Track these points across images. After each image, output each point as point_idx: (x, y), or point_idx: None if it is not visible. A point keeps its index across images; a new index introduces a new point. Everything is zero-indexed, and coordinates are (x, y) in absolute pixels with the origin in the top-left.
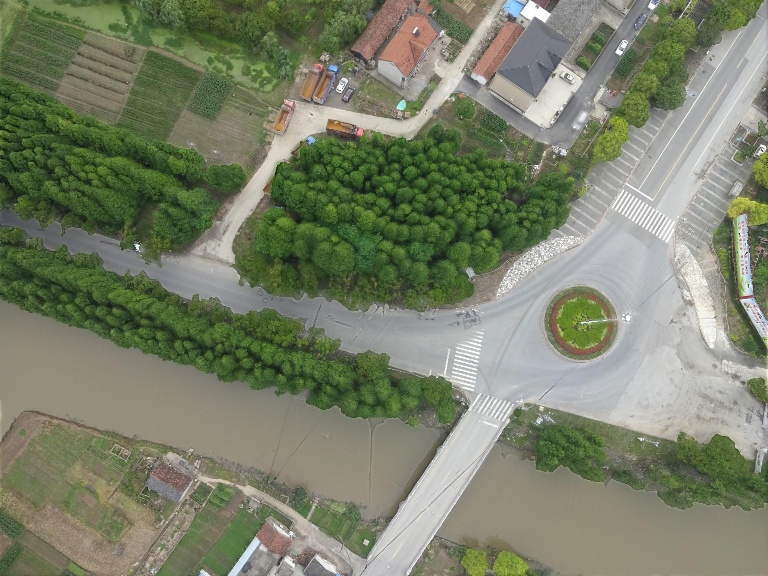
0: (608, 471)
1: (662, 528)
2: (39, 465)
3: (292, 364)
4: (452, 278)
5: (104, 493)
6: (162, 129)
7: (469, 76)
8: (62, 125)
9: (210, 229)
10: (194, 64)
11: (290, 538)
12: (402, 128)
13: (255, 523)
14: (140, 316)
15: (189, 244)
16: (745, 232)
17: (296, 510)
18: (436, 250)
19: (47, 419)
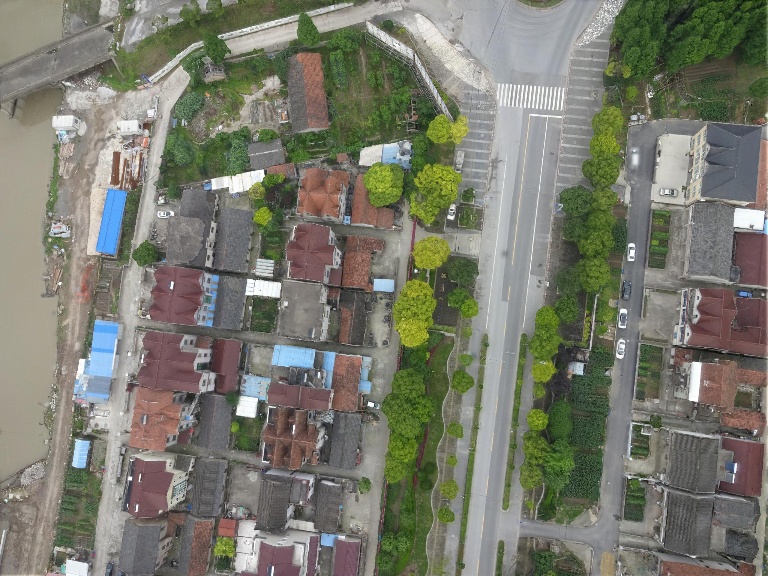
0: None
1: None
2: None
3: None
4: None
5: None
6: None
7: None
8: None
9: None
10: None
11: None
12: None
13: None
14: None
15: None
16: None
17: None
18: None
19: None
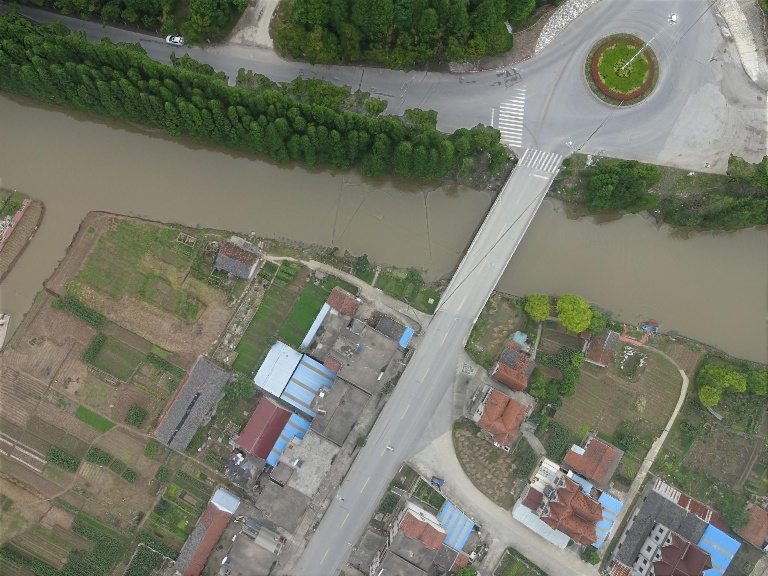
0: (660, 215)
1: (715, 277)
2: (111, 260)
3: (344, 116)
4: (492, 19)
5: (176, 280)
6: None
7: None
8: None
9: (245, 16)
10: None
11: (358, 301)
12: None
13: (323, 294)
14: (191, 87)
15: (226, 33)
16: None
17: (360, 278)
18: None
19: (112, 216)
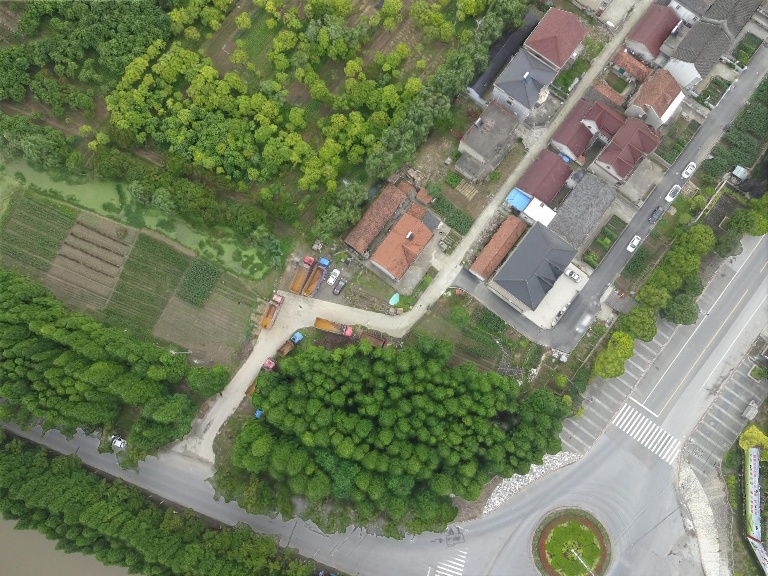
0: None
1: None
2: None
3: None
4: (431, 515)
5: None
6: (150, 316)
7: (467, 270)
8: (44, 333)
9: (191, 426)
10: (185, 248)
11: None
12: (394, 324)
13: None
14: (110, 537)
15: None
16: (756, 469)
17: None
18: (417, 479)
19: None
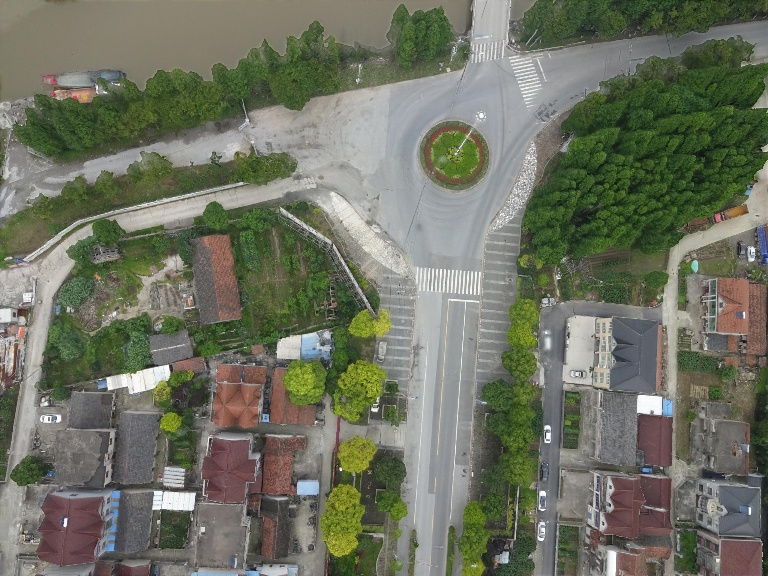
0: None
1: None
2: None
3: None
4: (604, 109)
5: None
6: None
7: None
8: None
9: None
10: None
11: None
12: (684, 247)
13: None
14: None
15: None
16: (367, 300)
17: None
18: (624, 131)
19: None
